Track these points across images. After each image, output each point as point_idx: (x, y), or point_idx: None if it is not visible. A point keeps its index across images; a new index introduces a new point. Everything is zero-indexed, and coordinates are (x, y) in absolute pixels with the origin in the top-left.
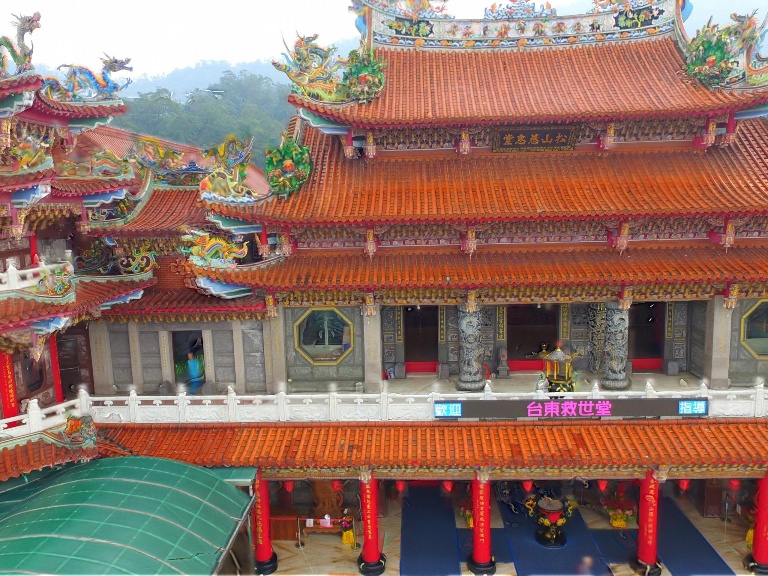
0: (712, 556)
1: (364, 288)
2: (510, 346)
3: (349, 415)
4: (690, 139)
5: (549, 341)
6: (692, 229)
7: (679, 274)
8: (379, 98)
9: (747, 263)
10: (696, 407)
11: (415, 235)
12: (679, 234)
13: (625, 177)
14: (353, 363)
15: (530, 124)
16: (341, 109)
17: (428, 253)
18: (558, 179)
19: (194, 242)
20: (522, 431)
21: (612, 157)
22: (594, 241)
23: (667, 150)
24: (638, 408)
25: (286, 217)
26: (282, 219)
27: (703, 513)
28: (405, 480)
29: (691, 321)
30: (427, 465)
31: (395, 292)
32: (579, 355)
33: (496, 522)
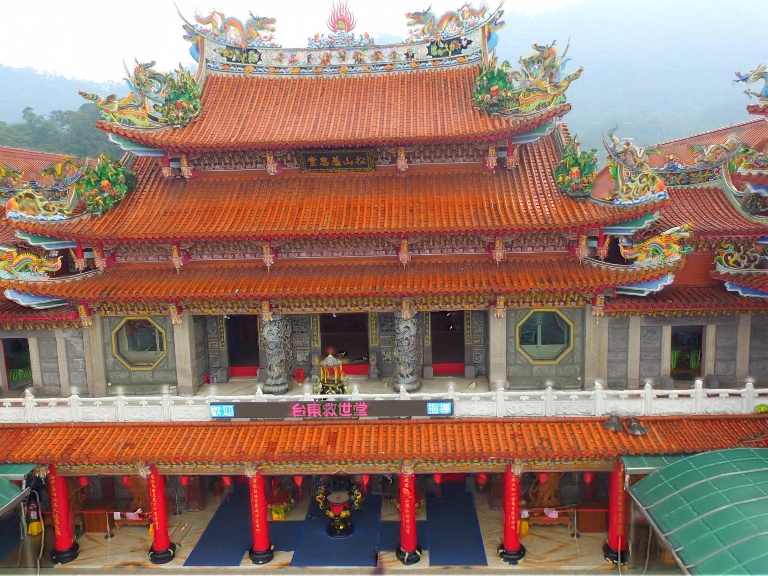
0: (476, 544)
1: (162, 299)
2: (324, 352)
3: (136, 416)
4: (480, 161)
5: (363, 347)
6: (472, 245)
7: (443, 287)
8: (196, 122)
9: (511, 276)
10: (442, 408)
11: (223, 250)
12: (461, 249)
13: (413, 197)
14: (167, 368)
15: (325, 148)
16: (155, 133)
17: (235, 266)
18: (353, 198)
19: (0, 257)
20: (286, 430)
21: (409, 178)
22: (385, 255)
23: (460, 171)
24: (391, 409)
25: (91, 234)
26: (87, 236)
27: (490, 506)
28: (187, 475)
29: (486, 329)
30: (188, 461)
31: (198, 303)
32: (387, 360)
33: (299, 515)
